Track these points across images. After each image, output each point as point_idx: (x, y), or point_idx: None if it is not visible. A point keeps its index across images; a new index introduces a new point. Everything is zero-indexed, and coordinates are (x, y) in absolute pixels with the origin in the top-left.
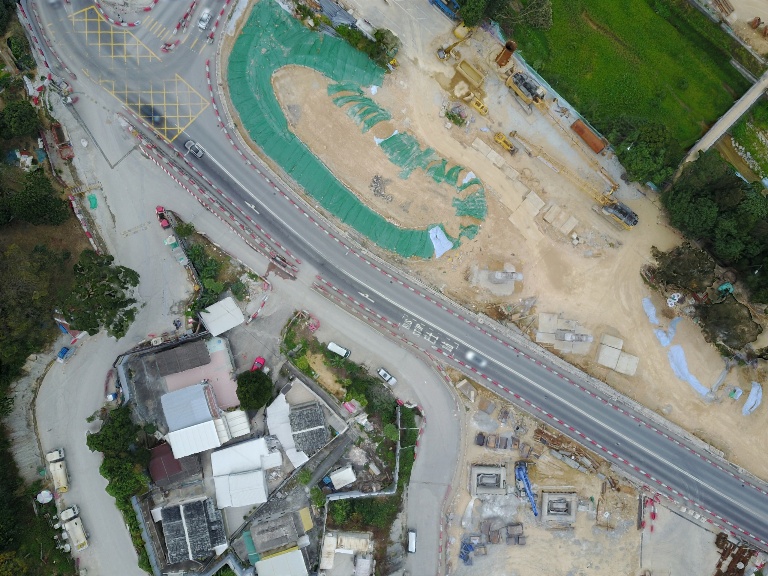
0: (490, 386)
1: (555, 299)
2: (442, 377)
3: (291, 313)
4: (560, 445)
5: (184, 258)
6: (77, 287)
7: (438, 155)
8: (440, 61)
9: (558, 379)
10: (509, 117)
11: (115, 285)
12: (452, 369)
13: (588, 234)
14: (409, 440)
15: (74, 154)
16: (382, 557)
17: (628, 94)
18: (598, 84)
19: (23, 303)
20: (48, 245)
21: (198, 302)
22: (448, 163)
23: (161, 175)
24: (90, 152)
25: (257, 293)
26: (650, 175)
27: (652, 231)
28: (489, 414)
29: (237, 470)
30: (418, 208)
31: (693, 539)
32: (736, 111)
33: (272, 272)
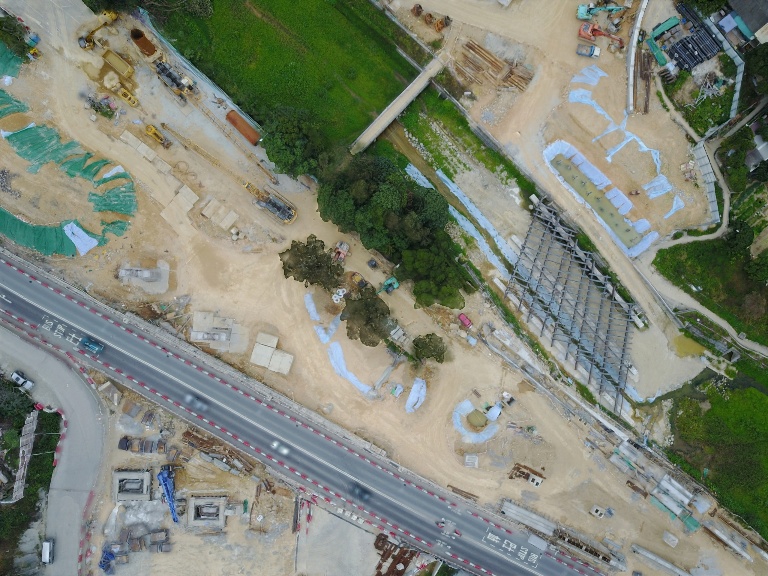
0: (137, 388)
1: (211, 297)
2: (83, 380)
3: None
4: (210, 448)
5: None
6: None
7: (83, 149)
8: (85, 51)
9: (211, 379)
10: (163, 109)
11: None
12: (96, 371)
13: (249, 229)
14: (48, 446)
15: None
16: (6, 569)
17: (294, 84)
18: (263, 74)
19: None
20: None
21: None
22: (93, 157)
23: None
24: None
25: None
26: (296, 167)
27: (318, 225)
28: (133, 417)
29: None
30: (48, 204)
31: (352, 541)
32: (402, 101)
33: None
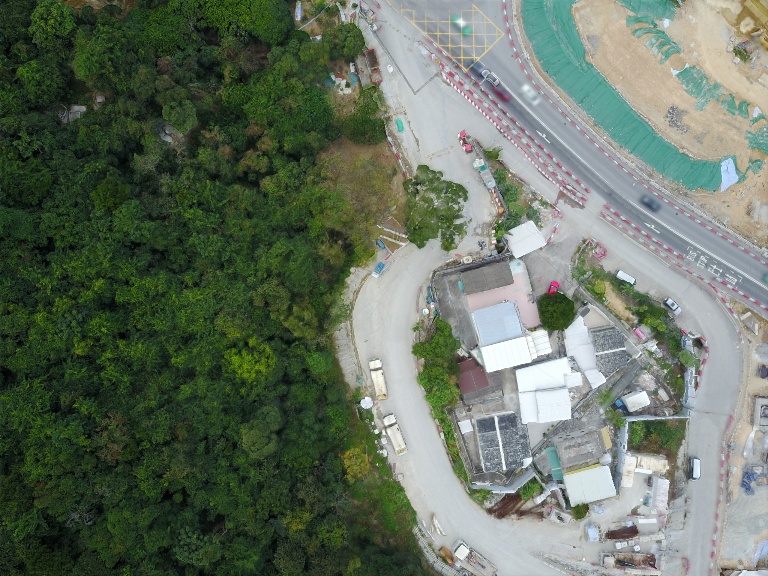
0: None
1: None
2: (727, 309)
3: (579, 241)
4: None
5: (492, 180)
6: (425, 197)
7: (725, 90)
8: None
9: None
10: None
11: (455, 197)
12: (735, 302)
13: None
14: None
15: (382, 79)
16: (672, 481)
17: None
18: None
19: (381, 209)
20: (378, 161)
21: (505, 224)
22: (735, 98)
23: (461, 102)
24: (394, 78)
25: (548, 220)
26: None
27: None
28: None
29: (542, 387)
30: (713, 139)
31: None
32: None
33: (561, 200)
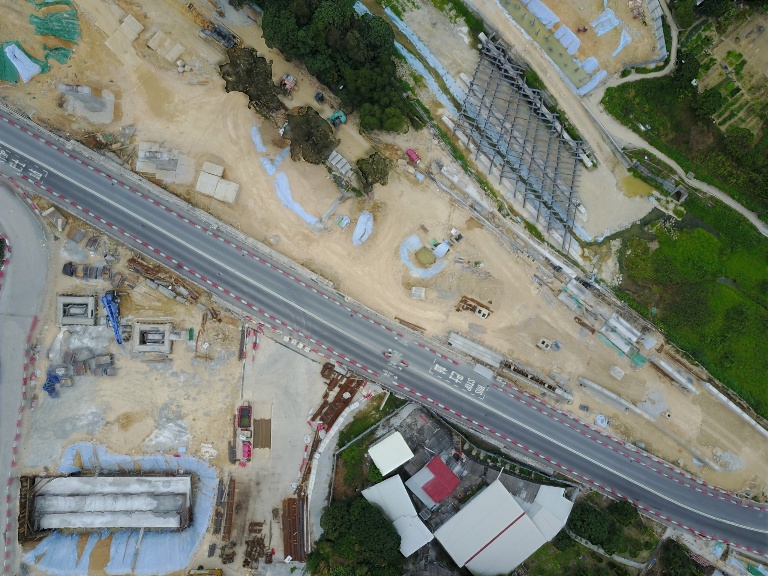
0: (81, 215)
1: (156, 127)
2: (27, 205)
3: None
4: (155, 275)
5: None
6: None
7: None
8: None
9: (156, 208)
10: None
11: None
12: (40, 197)
13: (195, 62)
14: None
15: None
16: None
17: None
18: None
19: None
20: None
21: None
22: None
23: None
24: None
25: None
26: None
27: None
28: (78, 243)
29: None
30: None
31: (298, 370)
32: None
33: None
